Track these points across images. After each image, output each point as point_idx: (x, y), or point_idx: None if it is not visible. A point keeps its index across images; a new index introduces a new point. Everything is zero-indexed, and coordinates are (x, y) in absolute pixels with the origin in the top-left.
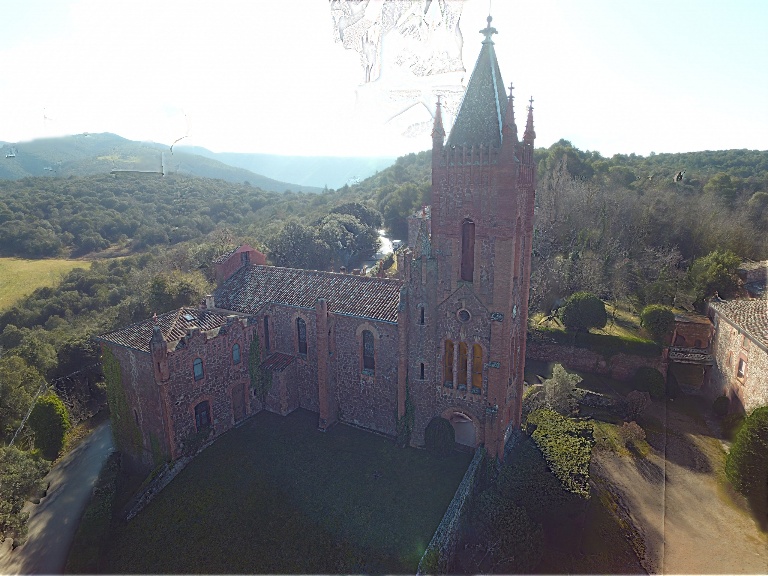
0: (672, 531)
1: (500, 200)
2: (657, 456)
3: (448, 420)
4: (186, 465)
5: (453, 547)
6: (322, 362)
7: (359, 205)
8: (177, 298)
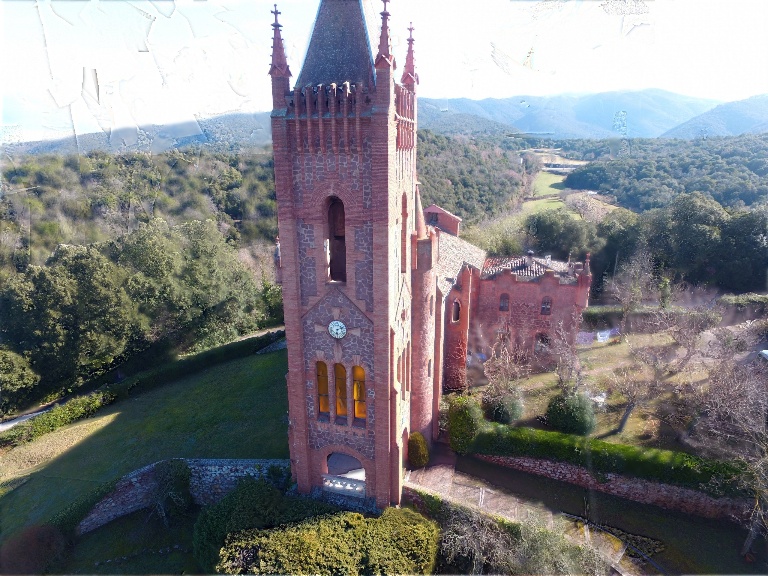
0: None
1: None
2: None
3: None
4: None
5: (223, 496)
6: None
7: None
8: None
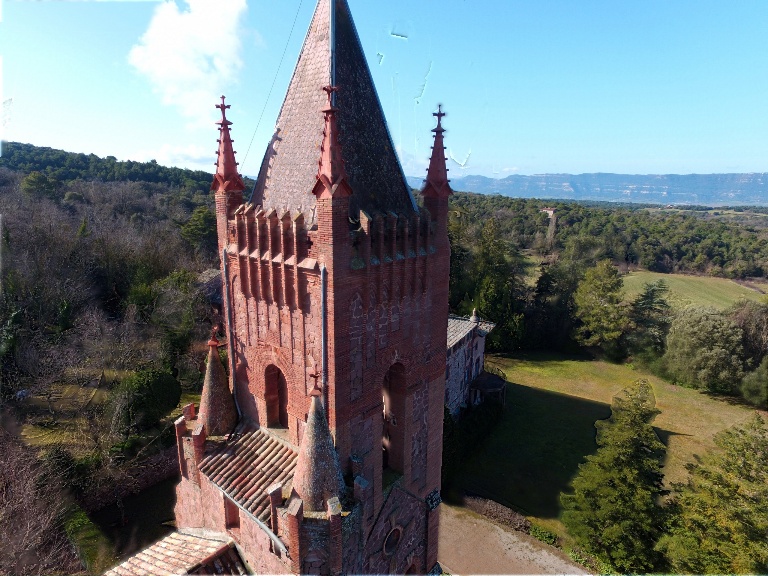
0: (453, 565)
1: (435, 313)
2: None
3: None
4: None
5: None
6: None
7: None
8: None
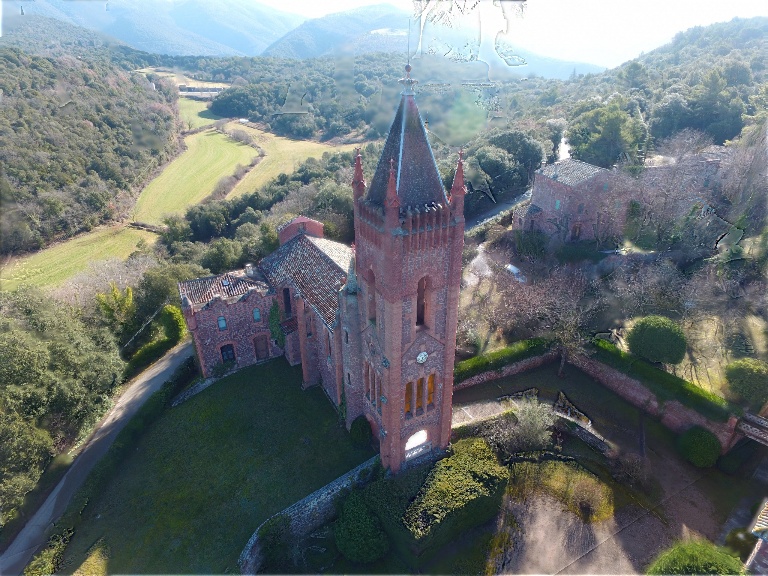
0: None
1: (385, 265)
2: (607, 528)
3: (369, 422)
4: (214, 383)
5: (320, 517)
6: (301, 341)
7: (522, 135)
8: (275, 242)
